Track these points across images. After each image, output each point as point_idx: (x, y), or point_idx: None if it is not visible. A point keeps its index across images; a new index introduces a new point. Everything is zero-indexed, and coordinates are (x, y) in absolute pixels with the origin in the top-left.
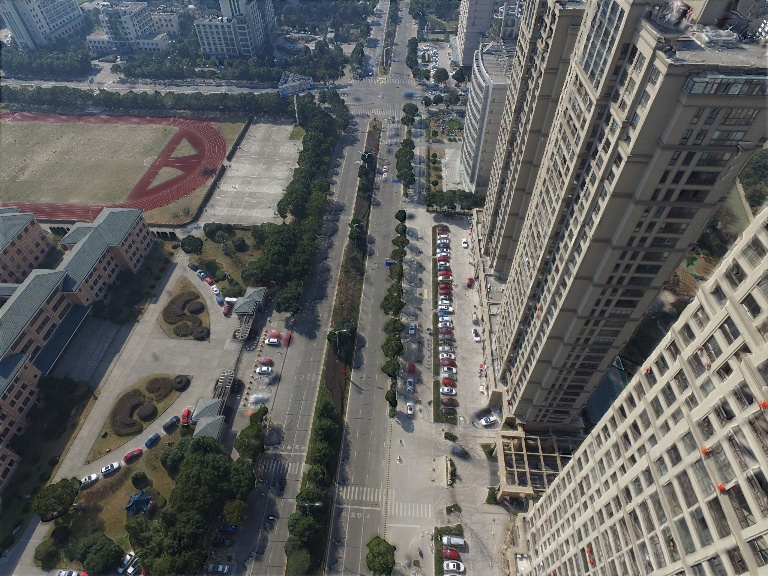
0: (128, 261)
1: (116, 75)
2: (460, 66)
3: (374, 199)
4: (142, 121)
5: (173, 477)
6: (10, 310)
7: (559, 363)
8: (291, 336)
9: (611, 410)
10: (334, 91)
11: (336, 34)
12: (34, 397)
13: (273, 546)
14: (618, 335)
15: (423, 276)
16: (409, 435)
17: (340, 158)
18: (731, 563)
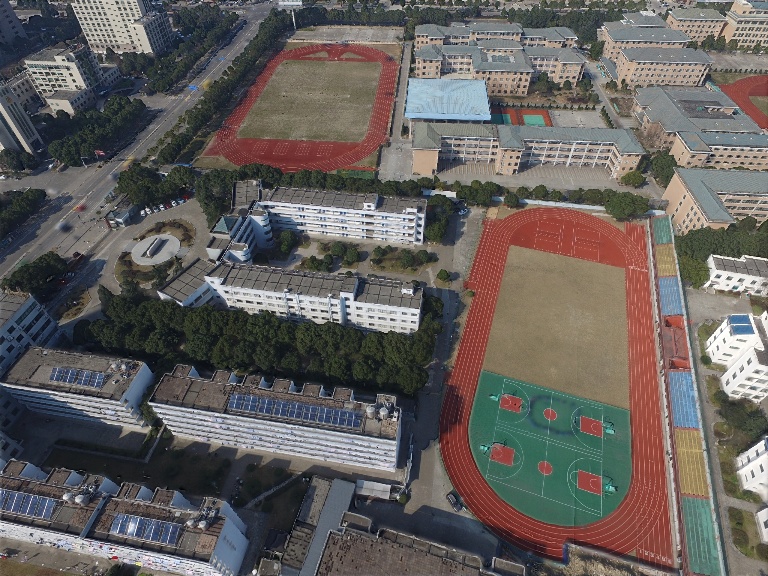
0: None
1: (157, 97)
2: None
3: None
4: (269, 72)
5: None
6: None
7: None
8: None
9: None
10: None
11: None
12: None
13: None
14: None
15: (435, 7)
16: None
17: None
18: None
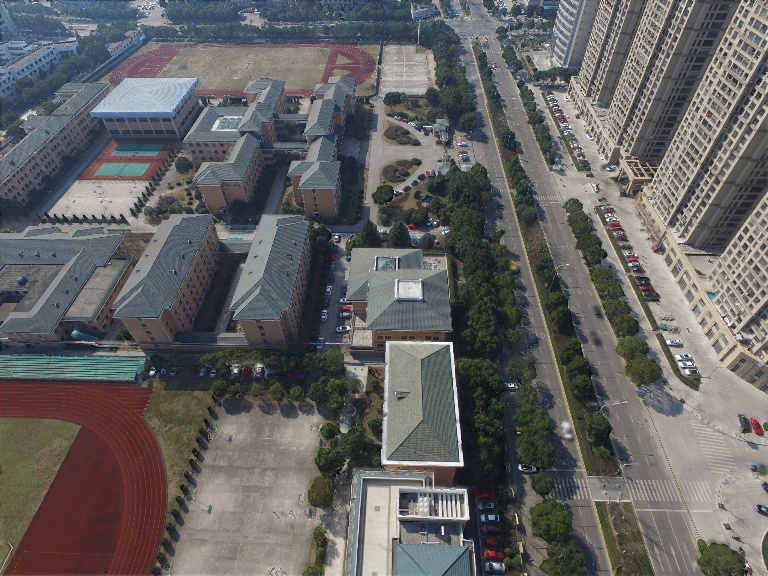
0: (352, 108)
1: (260, 20)
2: (524, 8)
3: (494, 81)
4: (300, 46)
5: None
6: (321, 112)
7: (667, 96)
8: (472, 143)
9: (714, 56)
10: (442, 21)
11: None
12: None
13: (507, 216)
14: (701, 69)
15: (544, 115)
16: (565, 177)
17: (459, 62)
18: None
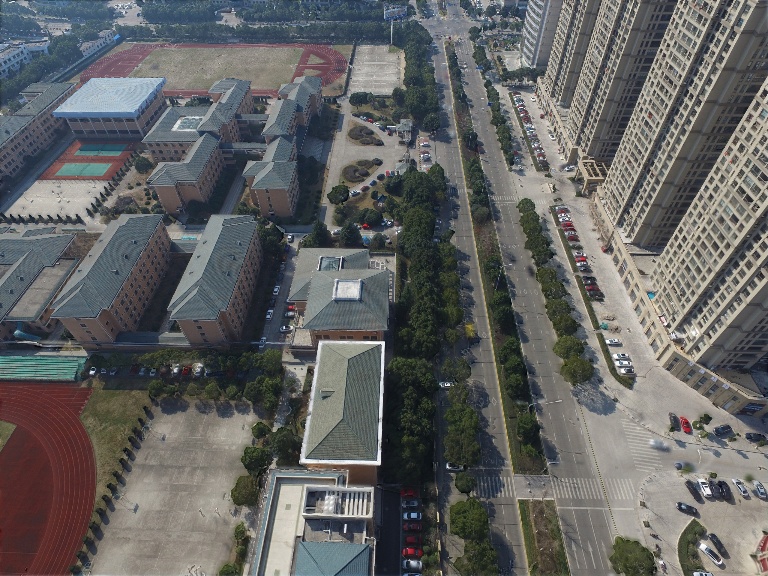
0: None
1: (237, 20)
2: (501, 8)
3: (463, 81)
4: (274, 46)
5: (393, 195)
6: (280, 112)
7: (618, 97)
8: (435, 143)
9: (656, 57)
10: (416, 21)
11: None
12: (296, 165)
13: (462, 216)
14: None
15: (510, 115)
16: (523, 177)
17: (430, 62)
18: (703, 26)
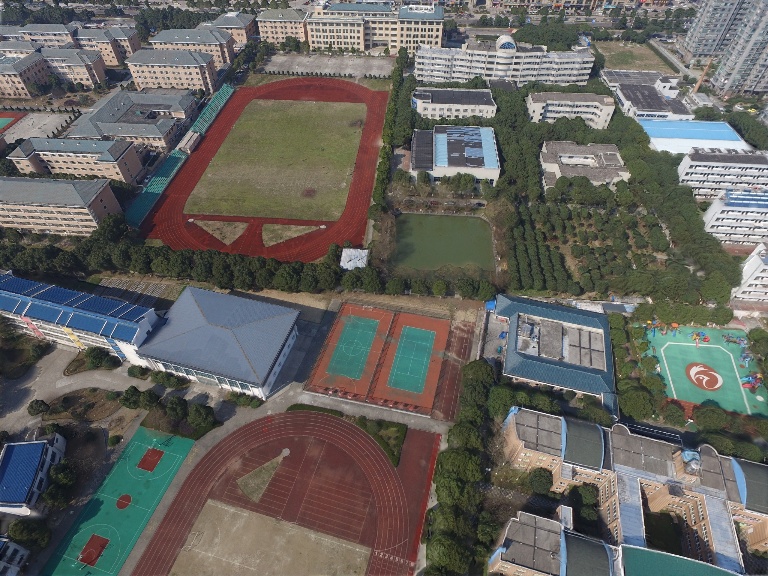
0: None
1: None
2: None
3: None
4: None
5: None
6: None
7: None
8: None
9: None
10: None
11: None
12: None
13: None
14: None
15: None
16: None
17: None
18: None
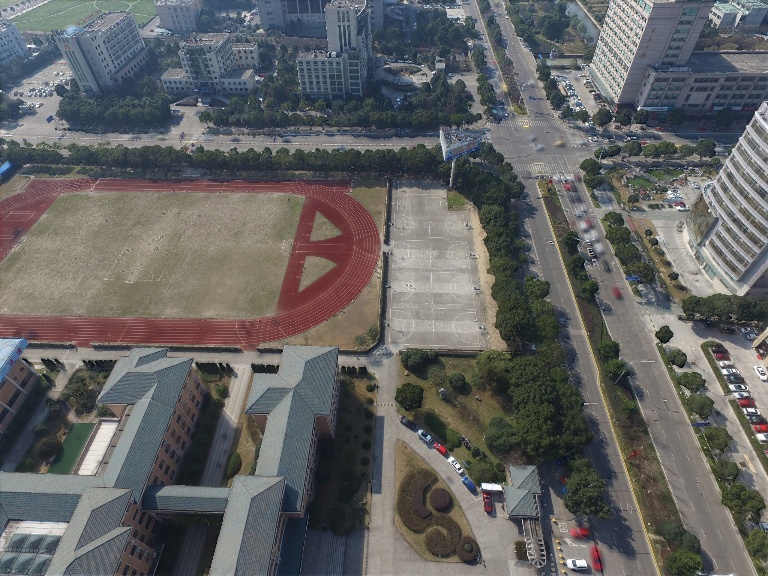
0: (330, 426)
1: (203, 123)
2: (609, 102)
3: (599, 301)
4: (256, 188)
5: None
6: None
7: None
8: (598, 550)
9: None
10: (490, 144)
11: (446, 64)
12: None
13: None
14: None
15: (730, 431)
16: None
17: (525, 237)
18: None
